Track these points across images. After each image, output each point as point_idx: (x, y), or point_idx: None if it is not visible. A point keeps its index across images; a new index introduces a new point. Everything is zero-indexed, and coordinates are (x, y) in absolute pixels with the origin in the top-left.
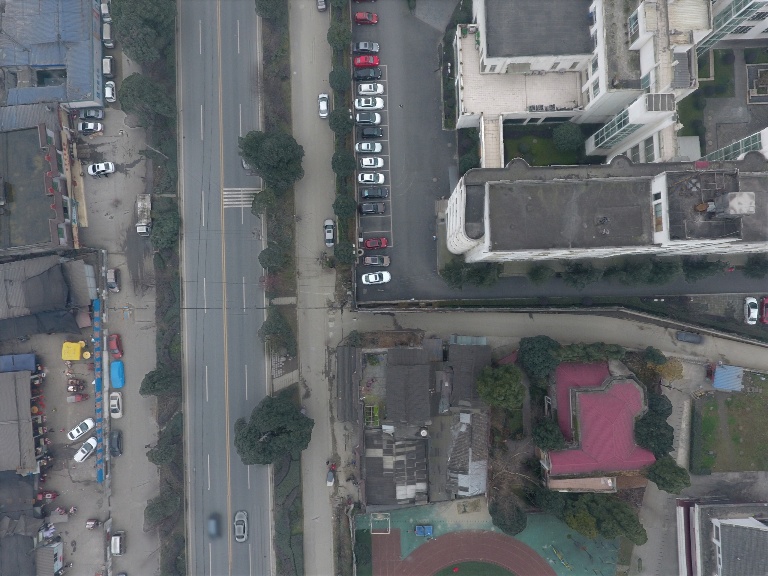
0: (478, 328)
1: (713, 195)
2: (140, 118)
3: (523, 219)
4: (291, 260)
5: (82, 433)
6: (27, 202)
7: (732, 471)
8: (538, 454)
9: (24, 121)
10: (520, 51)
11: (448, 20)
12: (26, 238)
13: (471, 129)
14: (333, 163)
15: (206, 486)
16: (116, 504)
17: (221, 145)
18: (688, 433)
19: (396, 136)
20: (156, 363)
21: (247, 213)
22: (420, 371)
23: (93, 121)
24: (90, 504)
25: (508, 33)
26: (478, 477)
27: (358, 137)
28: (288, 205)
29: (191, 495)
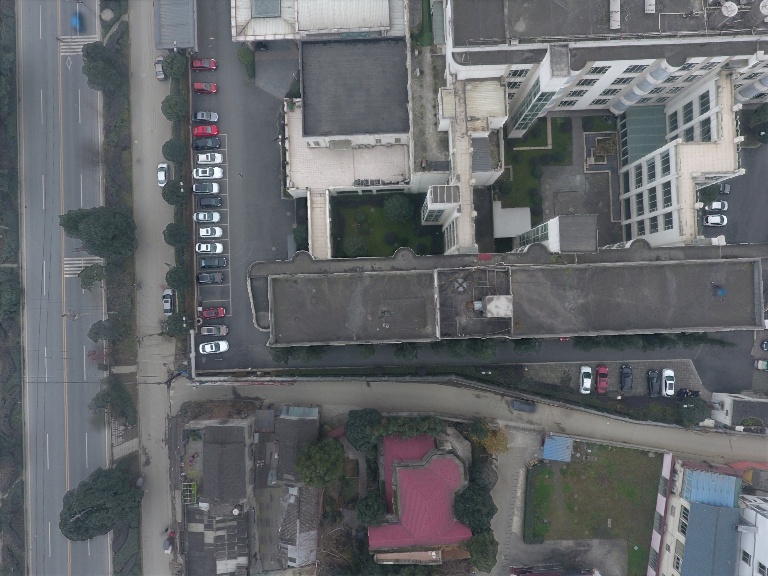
0: (316, 396)
1: (485, 292)
2: None
3: (308, 311)
4: (131, 329)
5: None
6: None
7: (566, 539)
8: None
9: None
10: (339, 129)
11: (288, 88)
12: None
13: None
14: (164, 236)
15: (47, 553)
16: None
17: (62, 214)
18: (523, 501)
19: (235, 205)
20: None
21: None
22: (235, 449)
23: None
24: None
25: (327, 111)
26: (307, 548)
27: (198, 206)
28: (127, 275)
29: (32, 562)
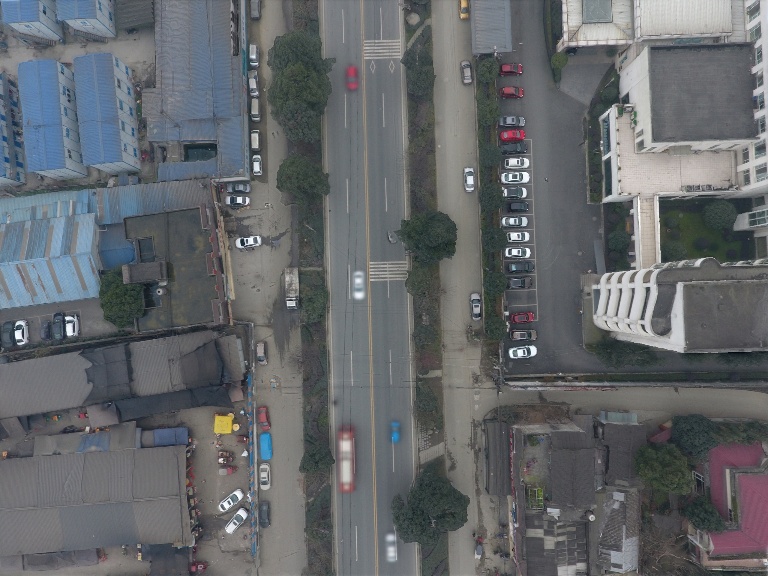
0: (623, 402)
1: None
2: (297, 197)
3: (714, 318)
4: (437, 333)
5: (232, 505)
6: (189, 282)
7: None
8: (685, 528)
9: (177, 197)
10: (683, 134)
11: (593, 93)
12: (188, 318)
13: (617, 204)
14: (486, 241)
15: (354, 557)
16: (264, 574)
17: (367, 218)
18: None
19: (541, 210)
20: (304, 435)
21: (393, 286)
22: (586, 455)
23: (240, 194)
24: (239, 574)
25: (671, 116)
26: (631, 554)
27: (503, 211)
28: (434, 279)
29: (339, 566)
